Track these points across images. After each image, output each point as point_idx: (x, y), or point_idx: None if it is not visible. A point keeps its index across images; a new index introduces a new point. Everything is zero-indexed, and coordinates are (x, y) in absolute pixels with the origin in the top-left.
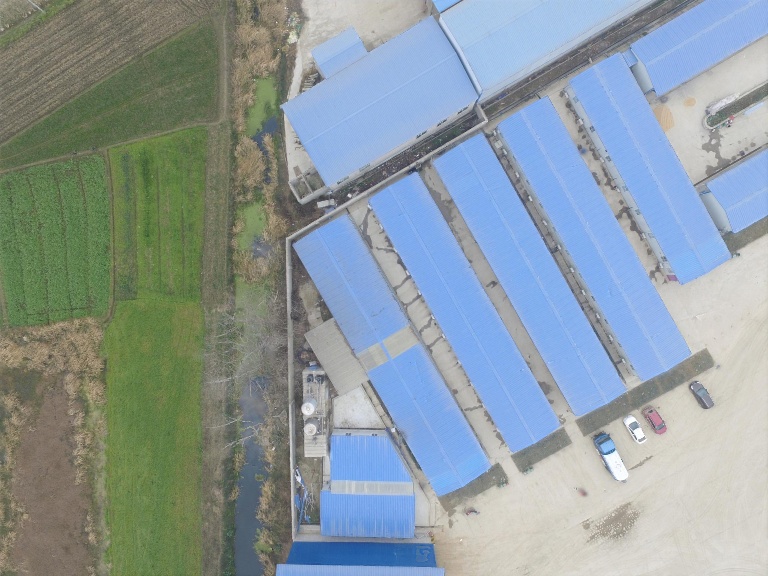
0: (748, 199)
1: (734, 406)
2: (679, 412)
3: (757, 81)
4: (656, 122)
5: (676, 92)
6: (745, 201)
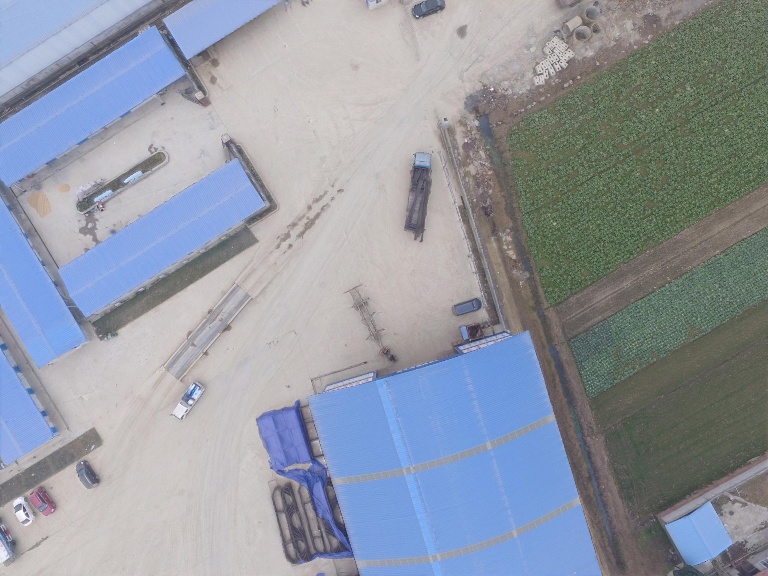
0: (90, 284)
1: (124, 484)
2: (71, 492)
3: (127, 166)
4: (7, 212)
5: (51, 179)
6: (88, 286)
